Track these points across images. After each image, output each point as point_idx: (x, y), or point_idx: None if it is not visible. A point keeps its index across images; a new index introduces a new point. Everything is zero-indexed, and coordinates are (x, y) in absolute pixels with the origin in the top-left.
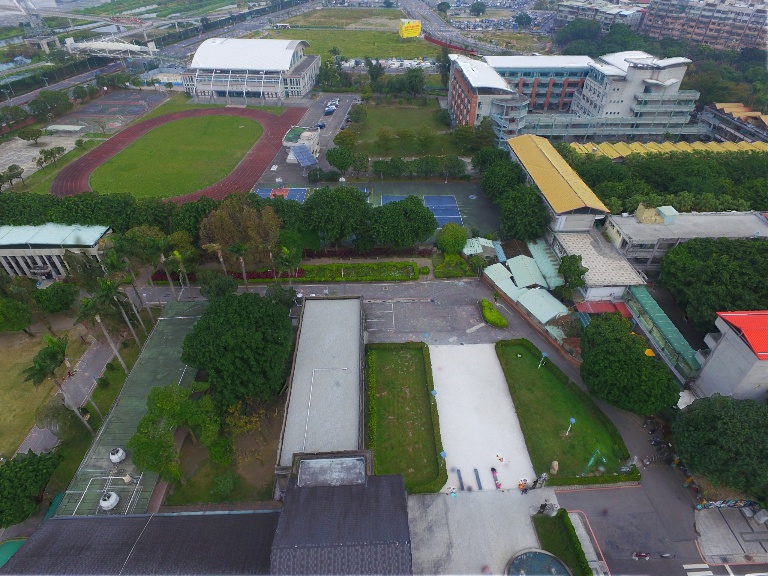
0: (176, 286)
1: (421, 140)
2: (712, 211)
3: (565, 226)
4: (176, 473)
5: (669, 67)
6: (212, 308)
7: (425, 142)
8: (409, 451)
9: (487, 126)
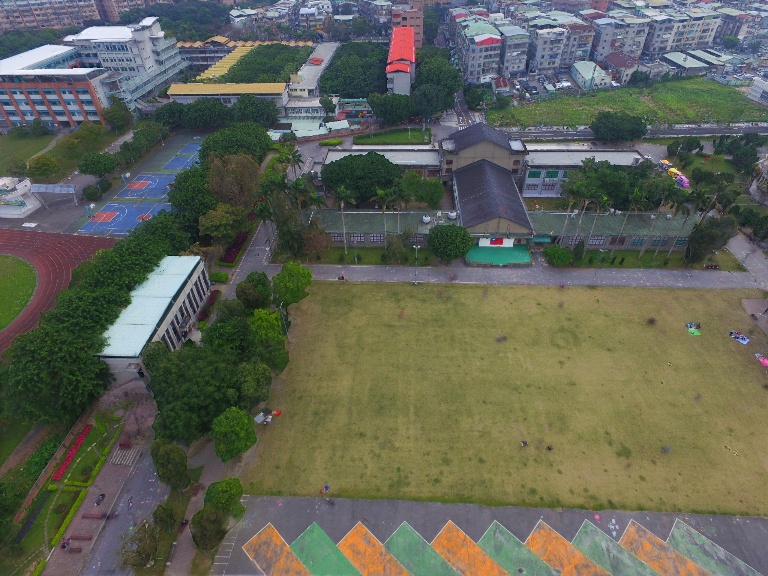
0: (245, 252)
1: (96, 133)
2: (298, 70)
3: (284, 101)
4: None
5: (153, 25)
6: (337, 176)
7: (100, 133)
8: None
9: (117, 102)
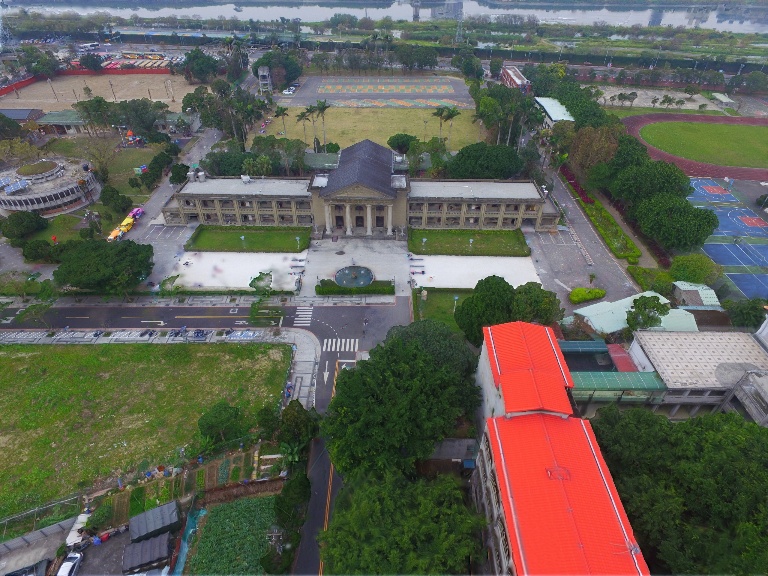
0: None
1: None
2: None
3: (767, 336)
4: (409, 167)
5: None
6: None
7: None
8: (435, 244)
9: None
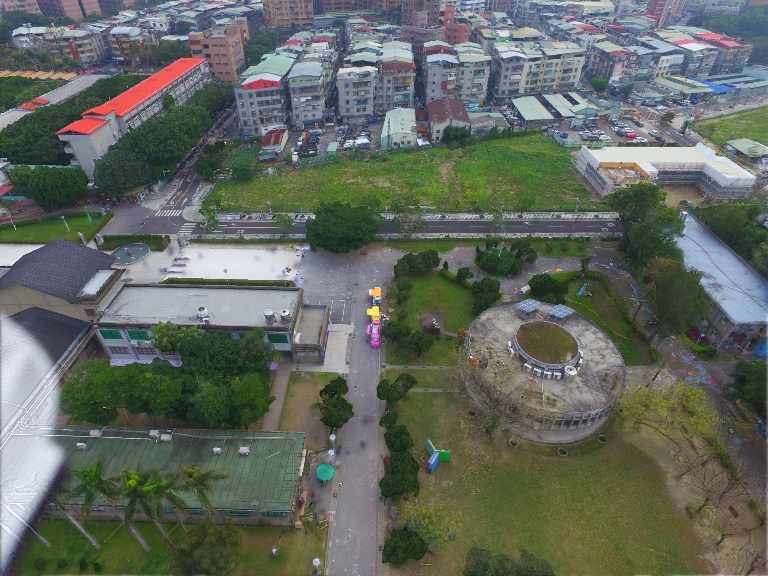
0: None
1: None
2: None
3: None
4: None
5: None
6: None
7: None
8: None
9: None
